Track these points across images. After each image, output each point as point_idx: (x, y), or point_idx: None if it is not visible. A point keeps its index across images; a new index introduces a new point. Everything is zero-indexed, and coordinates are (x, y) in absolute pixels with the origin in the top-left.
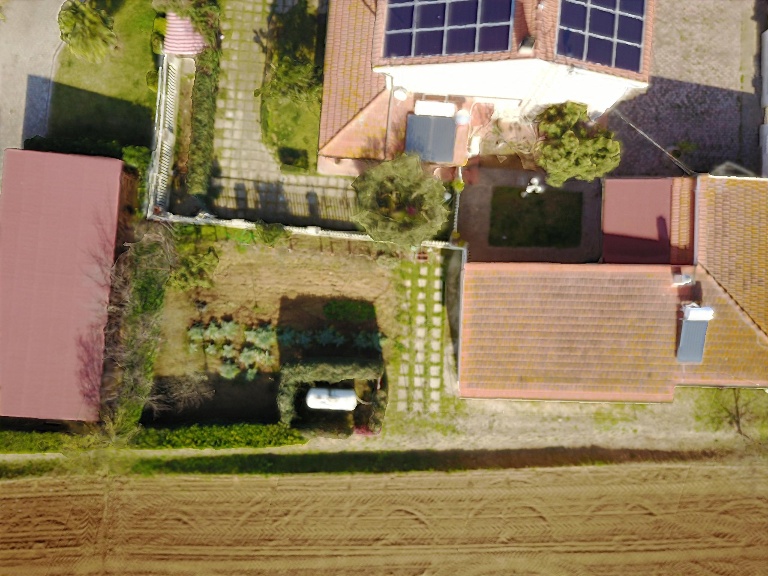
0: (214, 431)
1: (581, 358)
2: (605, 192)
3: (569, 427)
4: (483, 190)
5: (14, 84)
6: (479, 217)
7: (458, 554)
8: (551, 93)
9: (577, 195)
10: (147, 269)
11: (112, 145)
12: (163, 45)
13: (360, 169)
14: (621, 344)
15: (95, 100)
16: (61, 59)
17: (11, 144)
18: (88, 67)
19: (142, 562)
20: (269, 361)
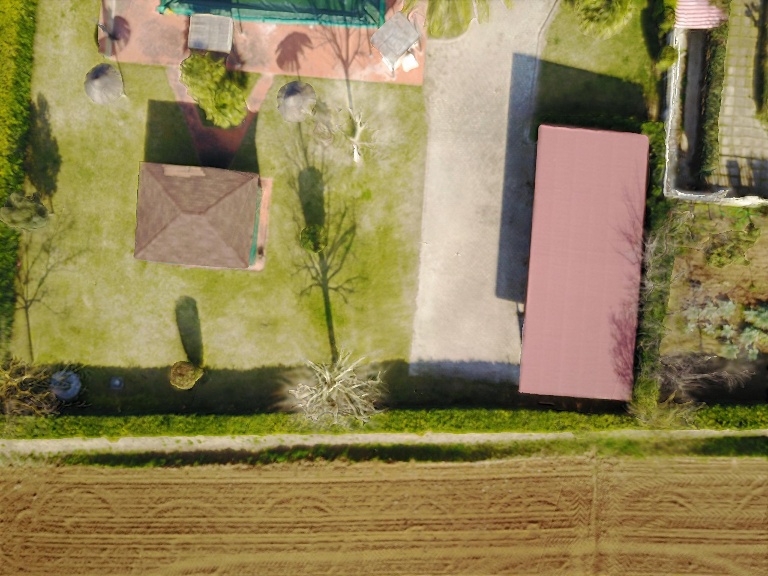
0: (737, 412)
1: None
2: None
3: None
4: None
5: (499, 63)
6: None
7: None
8: None
9: None
10: (673, 247)
11: (630, 121)
12: None
13: None
14: None
15: (583, 78)
16: (547, 37)
17: (497, 123)
18: (576, 44)
19: (638, 544)
20: None
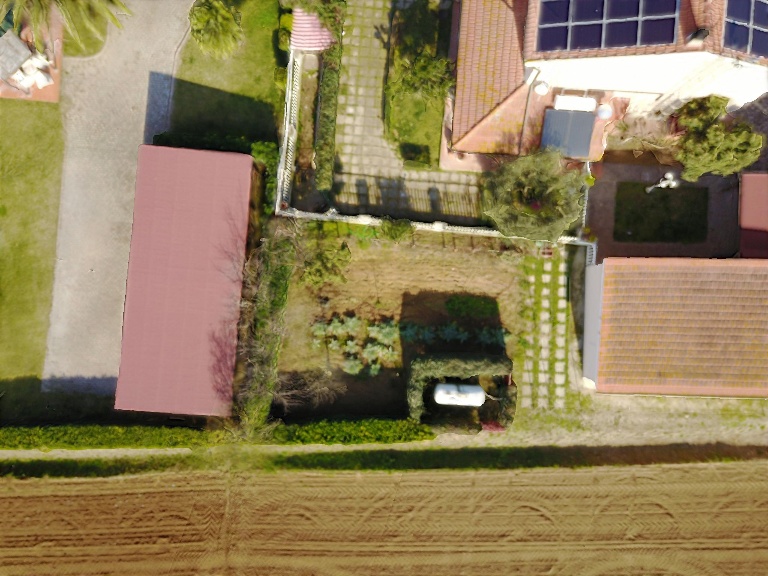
0: (343, 427)
1: (721, 354)
2: (742, 187)
3: (696, 423)
4: (607, 185)
5: (136, 81)
6: (603, 213)
7: (585, 551)
8: (698, 87)
9: (703, 190)
10: (277, 265)
11: (241, 141)
12: (290, 41)
13: (483, 165)
14: (762, 339)
15: (217, 96)
16: (183, 56)
17: (133, 140)
18: (210, 63)
19: (265, 557)
20: (392, 357)
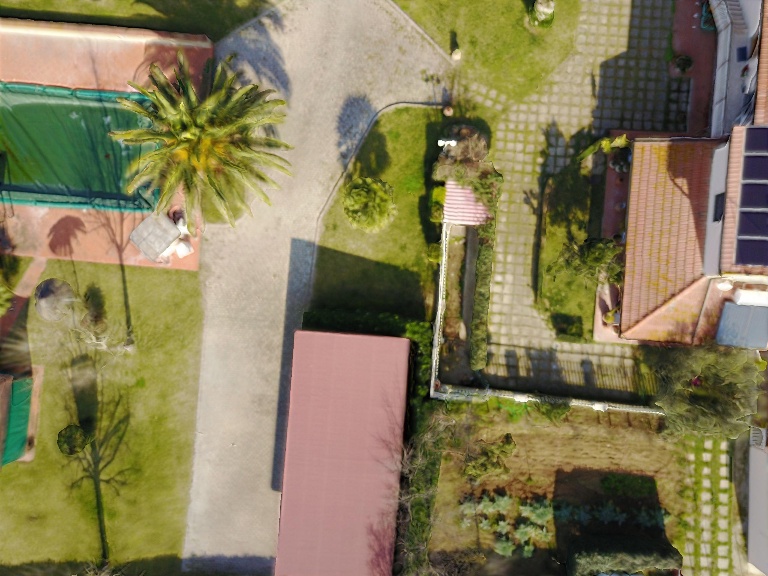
0: None
1: None
2: None
3: None
4: None
5: (277, 248)
6: (767, 389)
7: None
8: None
9: None
10: (435, 452)
11: (395, 321)
12: (443, 215)
13: None
14: None
15: (361, 264)
16: (326, 222)
17: (275, 309)
18: (354, 231)
19: None
20: (546, 538)
